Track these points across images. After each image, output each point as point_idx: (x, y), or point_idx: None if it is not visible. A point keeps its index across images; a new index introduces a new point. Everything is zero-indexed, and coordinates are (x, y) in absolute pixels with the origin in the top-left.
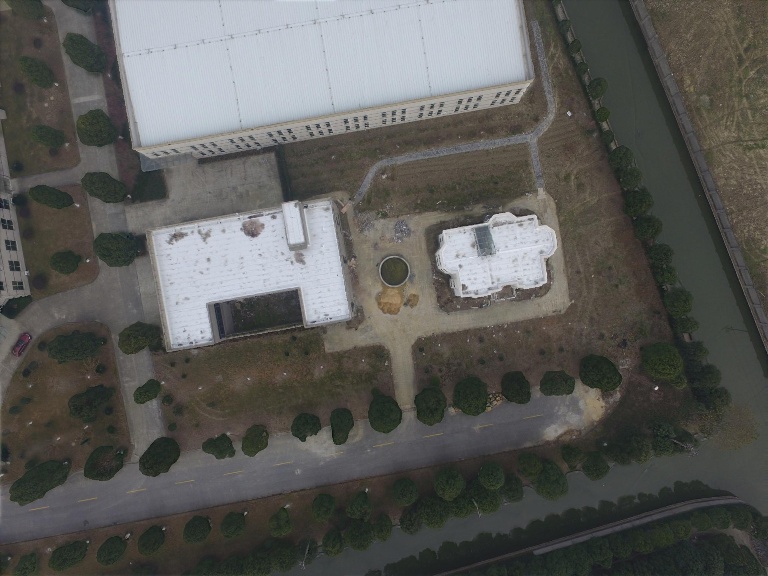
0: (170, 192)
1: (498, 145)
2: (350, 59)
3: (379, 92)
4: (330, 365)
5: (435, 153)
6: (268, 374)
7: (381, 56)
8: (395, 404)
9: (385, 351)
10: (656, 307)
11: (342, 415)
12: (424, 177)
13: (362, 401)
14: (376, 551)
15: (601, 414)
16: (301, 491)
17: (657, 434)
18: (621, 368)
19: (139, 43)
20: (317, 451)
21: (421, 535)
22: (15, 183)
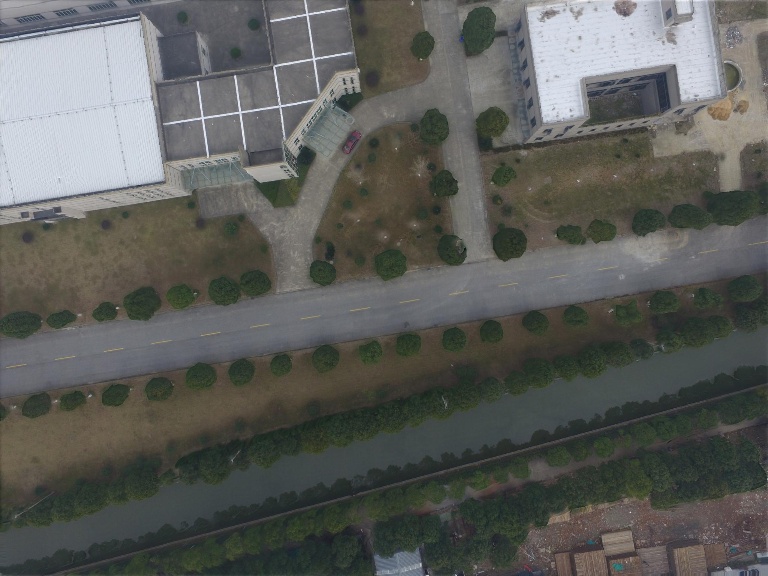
0: None
1: None
2: None
3: None
4: (660, 169)
5: None
6: (597, 177)
7: None
8: None
9: (714, 157)
10: None
11: None
12: None
13: None
14: (694, 361)
15: None
16: (625, 296)
17: None
18: None
19: None
20: (642, 256)
21: (748, 340)
22: None
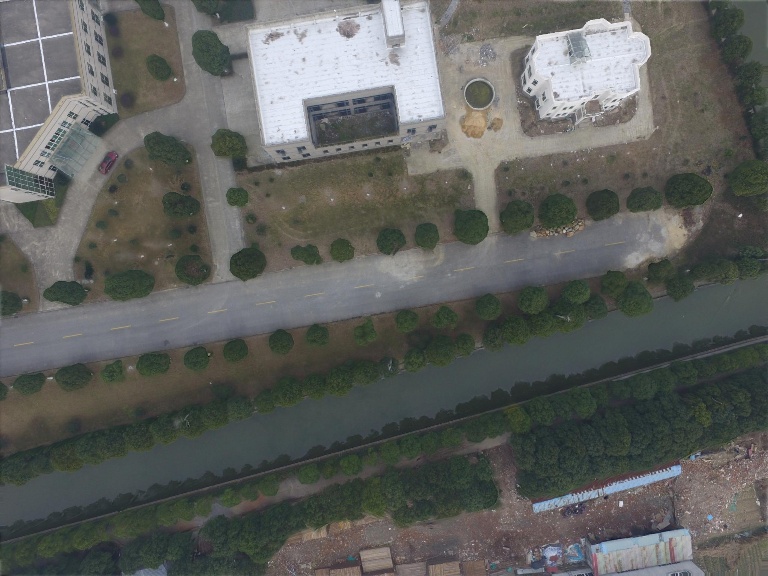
0: (257, 13)
1: None
2: None
3: None
4: (413, 187)
5: None
6: (351, 195)
7: None
8: None
9: (468, 175)
10: (741, 135)
11: (430, 225)
12: None
13: (444, 224)
14: (454, 378)
15: (683, 242)
16: (381, 314)
17: (743, 255)
18: None
19: None
20: (398, 274)
21: (501, 358)
22: (105, 3)
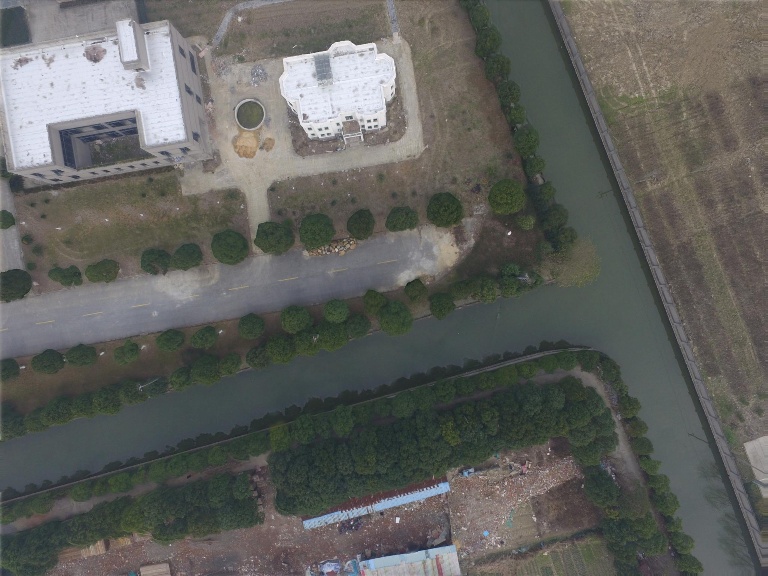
0: (33, 36)
1: None
2: None
3: None
4: (186, 207)
5: None
6: (126, 215)
7: None
8: (239, 235)
9: (241, 194)
10: (511, 153)
11: (187, 246)
12: (280, 21)
13: None
14: (233, 396)
15: (455, 260)
16: (158, 333)
17: (504, 273)
18: (475, 214)
19: None
20: (174, 293)
21: (273, 376)
22: None
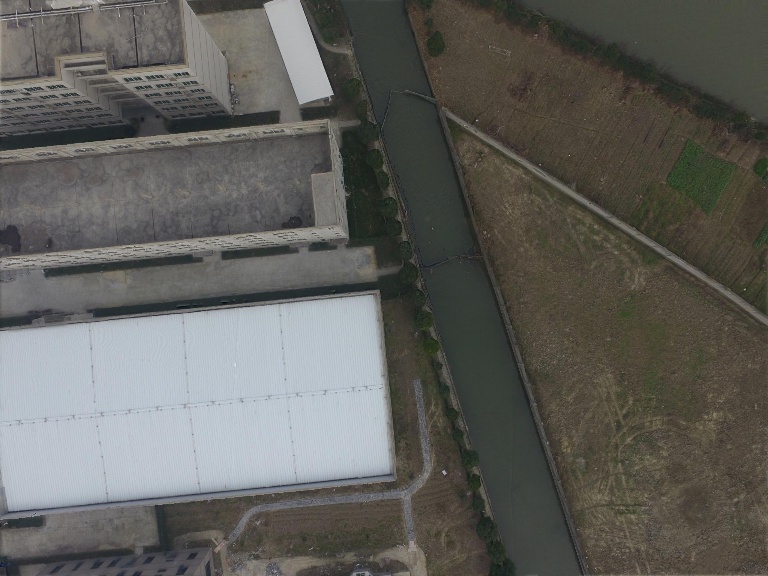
0: (47, 519)
1: (372, 499)
2: (218, 443)
3: (245, 475)
4: None
5: (310, 502)
6: None
7: (249, 442)
8: None
9: None
10: None
11: None
12: (297, 525)
13: None
14: None
15: None
16: None
17: None
18: None
19: (10, 413)
20: None
21: None
22: None
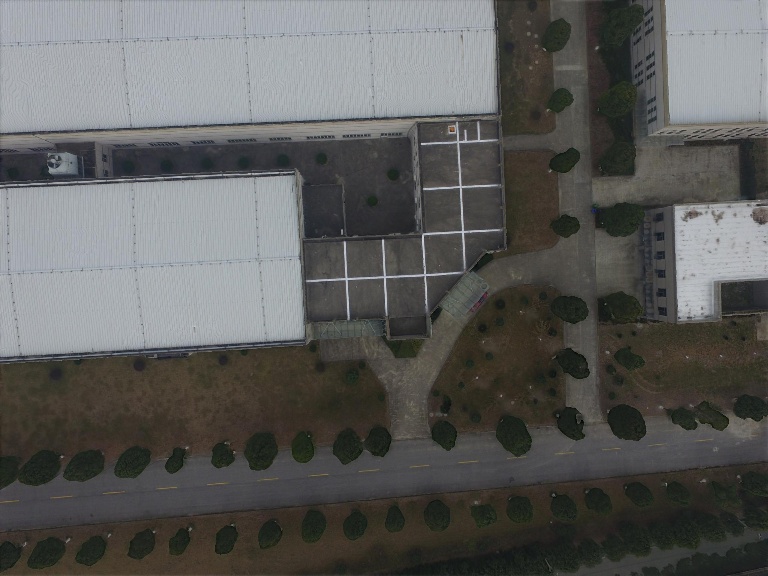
0: (637, 170)
1: None
2: None
3: None
4: (762, 352)
5: None
6: (705, 354)
7: None
8: None
9: None
10: None
11: None
12: None
13: None
14: None
15: None
16: (716, 468)
17: None
18: None
19: (682, 24)
20: (735, 432)
21: None
22: None
